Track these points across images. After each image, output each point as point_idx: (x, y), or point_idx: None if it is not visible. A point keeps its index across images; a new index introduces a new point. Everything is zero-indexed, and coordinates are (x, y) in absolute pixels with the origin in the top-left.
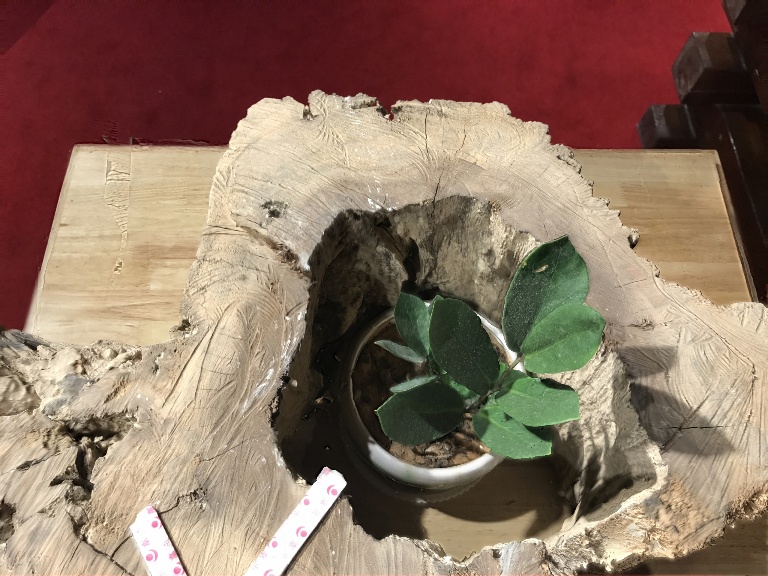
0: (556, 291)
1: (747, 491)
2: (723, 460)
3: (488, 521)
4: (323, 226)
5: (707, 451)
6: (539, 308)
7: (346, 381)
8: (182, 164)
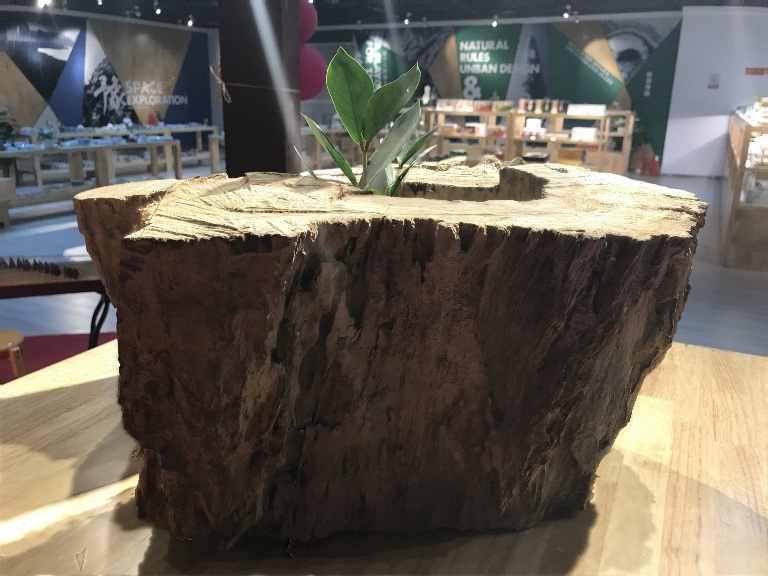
0: (390, 102)
1: None
2: None
3: None
4: (535, 173)
5: (217, 189)
6: (386, 116)
7: None
8: (767, 394)
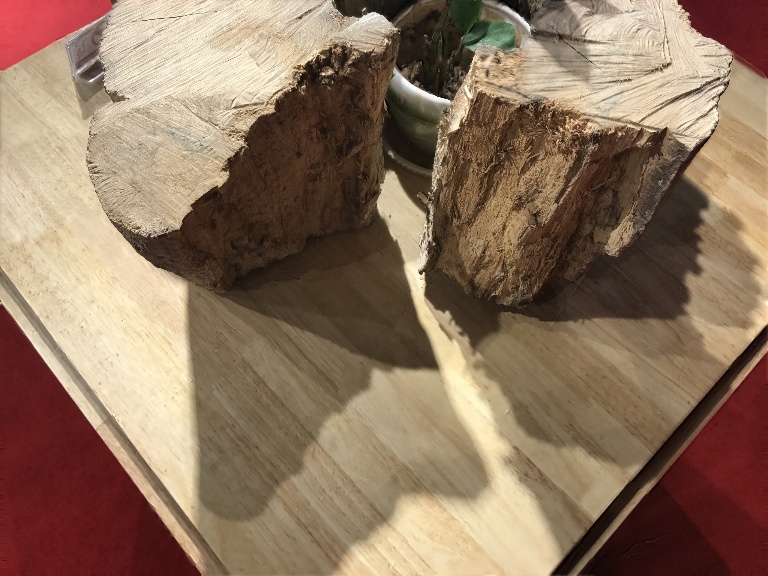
0: None
1: (566, 104)
2: (571, 78)
3: (422, 209)
4: None
5: (565, 64)
6: None
7: (408, 2)
8: None
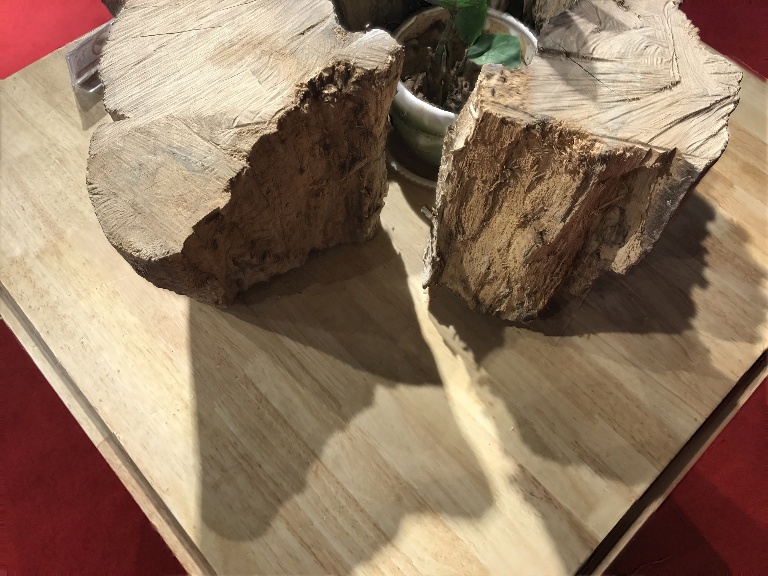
0: None
1: (573, 124)
2: (578, 97)
3: (425, 222)
4: None
5: (572, 83)
6: None
7: None
8: None
